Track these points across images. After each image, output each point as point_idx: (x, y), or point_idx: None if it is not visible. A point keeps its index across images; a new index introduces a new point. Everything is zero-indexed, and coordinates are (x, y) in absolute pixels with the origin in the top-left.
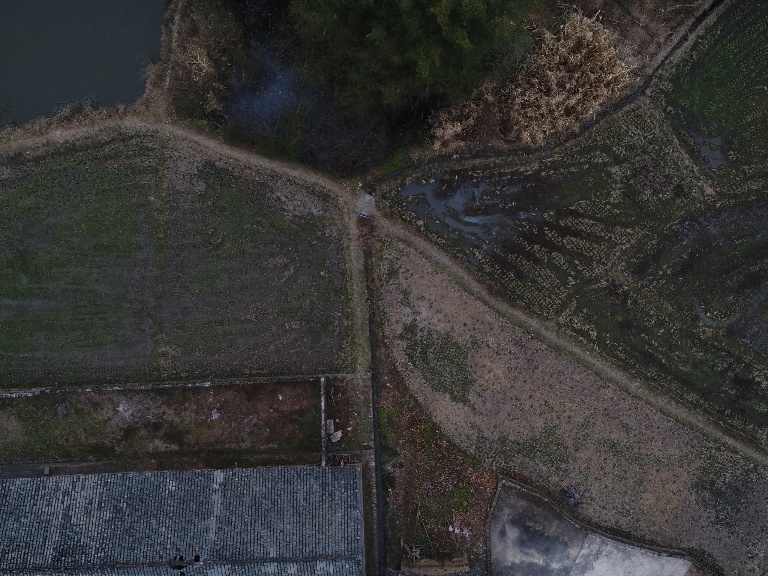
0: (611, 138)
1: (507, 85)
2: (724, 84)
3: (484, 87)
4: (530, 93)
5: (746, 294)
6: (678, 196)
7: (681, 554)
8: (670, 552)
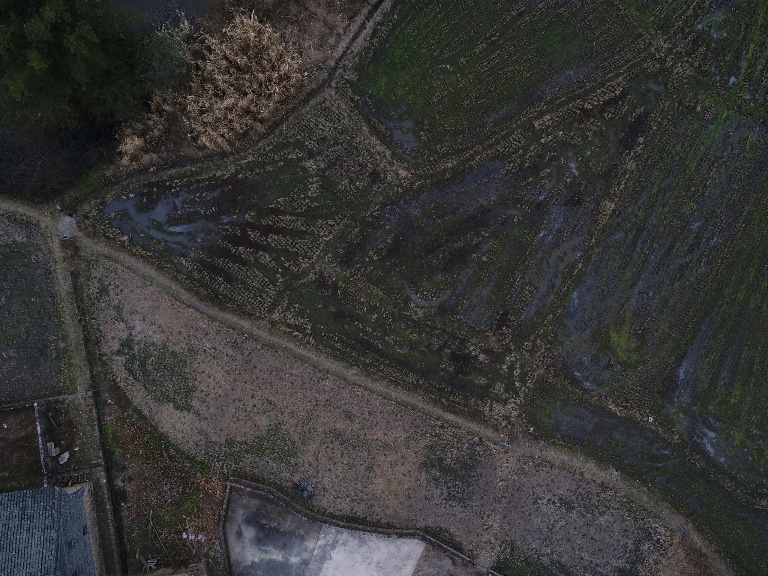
0: (302, 133)
1: (179, 94)
2: (407, 67)
3: (159, 98)
4: (202, 99)
5: (453, 271)
6: (375, 182)
7: (412, 534)
8: (402, 533)
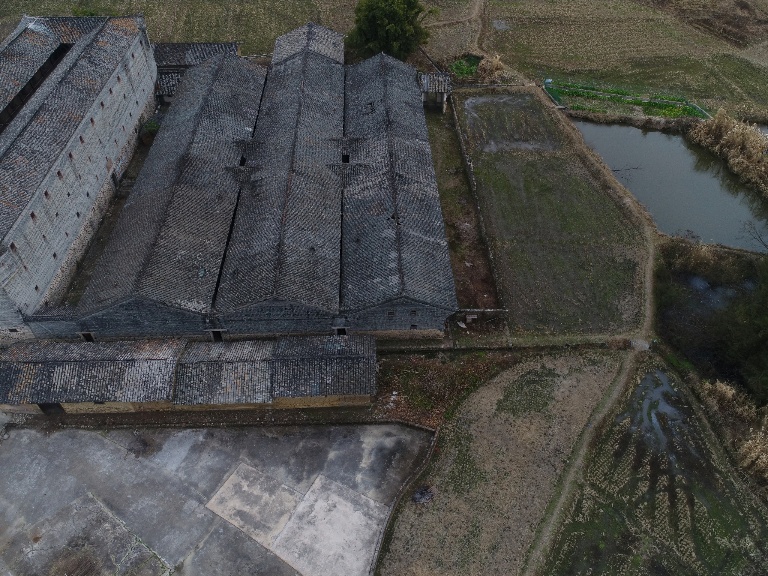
0: None
1: None
2: None
3: None
4: None
5: None
6: None
7: None
8: None
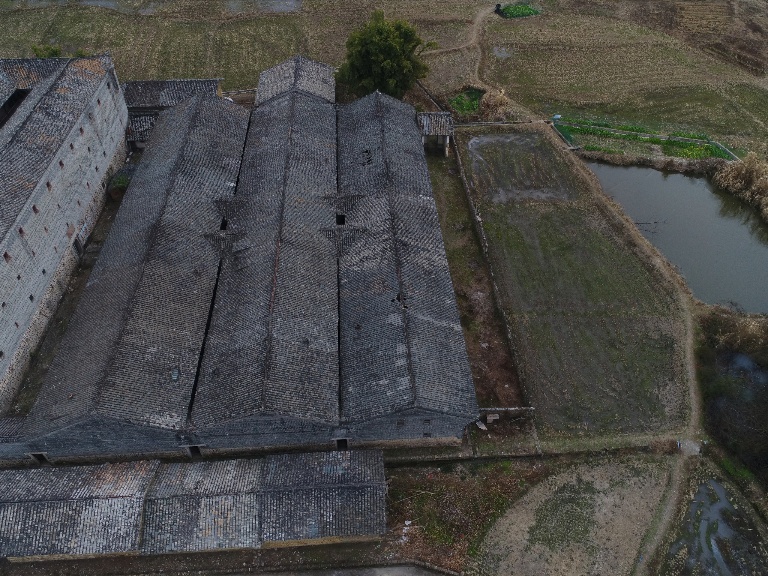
0: None
1: None
2: None
3: None
4: None
5: None
6: None
7: None
8: None
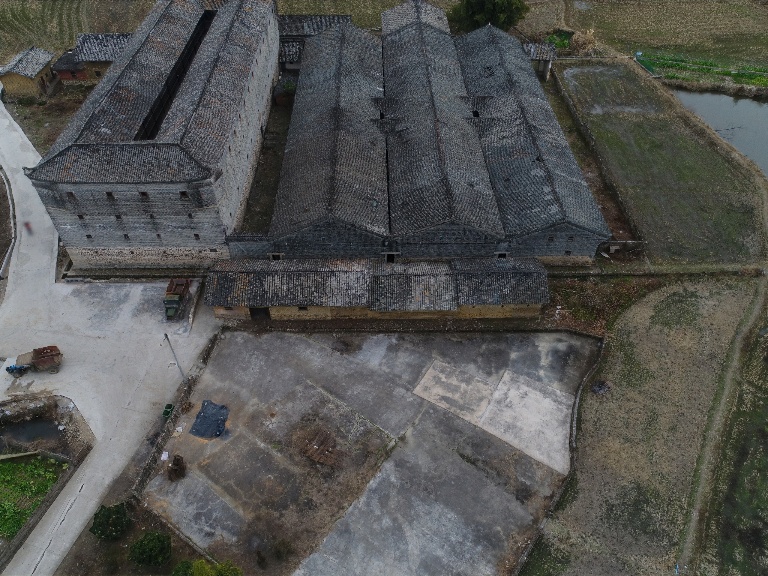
0: None
1: None
2: None
3: None
4: None
5: None
6: None
7: None
8: None
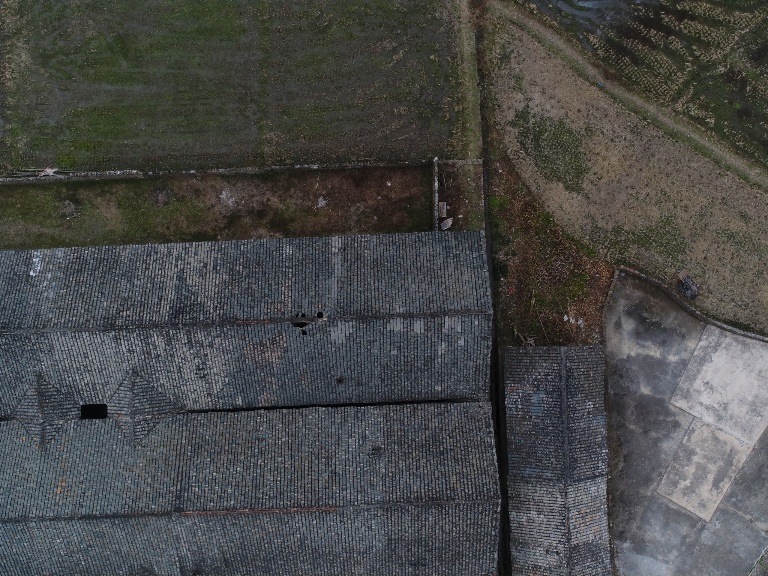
0: None
1: None
2: None
3: None
4: None
5: None
6: None
7: None
8: None
